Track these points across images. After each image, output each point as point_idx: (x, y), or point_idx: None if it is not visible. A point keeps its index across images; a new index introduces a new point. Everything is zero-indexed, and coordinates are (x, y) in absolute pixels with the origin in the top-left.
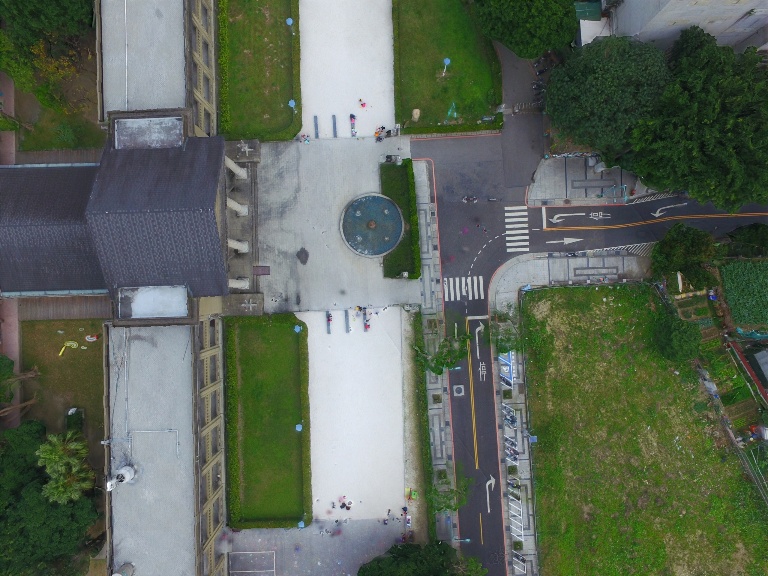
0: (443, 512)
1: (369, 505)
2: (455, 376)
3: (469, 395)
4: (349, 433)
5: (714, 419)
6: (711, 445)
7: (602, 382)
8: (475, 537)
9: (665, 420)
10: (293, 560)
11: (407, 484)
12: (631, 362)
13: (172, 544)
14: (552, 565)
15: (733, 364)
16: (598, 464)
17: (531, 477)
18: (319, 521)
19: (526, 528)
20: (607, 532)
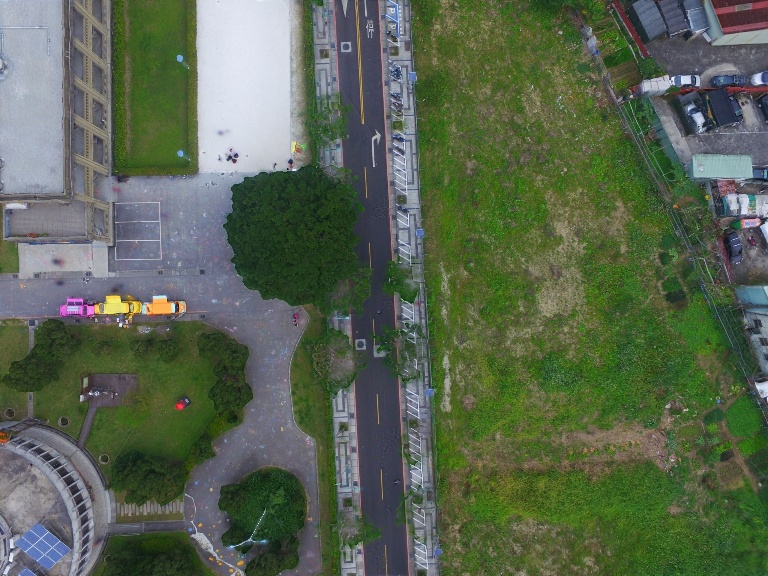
0: (328, 165)
1: (255, 159)
2: (343, 33)
3: (356, 52)
4: (237, 88)
5: (596, 80)
6: (593, 105)
7: (487, 40)
8: (360, 191)
9: (548, 79)
10: (178, 211)
11: (293, 138)
12: (516, 21)
13: (41, 141)
14: (434, 217)
15: (616, 28)
16: (482, 121)
17: (416, 132)
18: (205, 173)
19: (410, 183)
20: (490, 188)
